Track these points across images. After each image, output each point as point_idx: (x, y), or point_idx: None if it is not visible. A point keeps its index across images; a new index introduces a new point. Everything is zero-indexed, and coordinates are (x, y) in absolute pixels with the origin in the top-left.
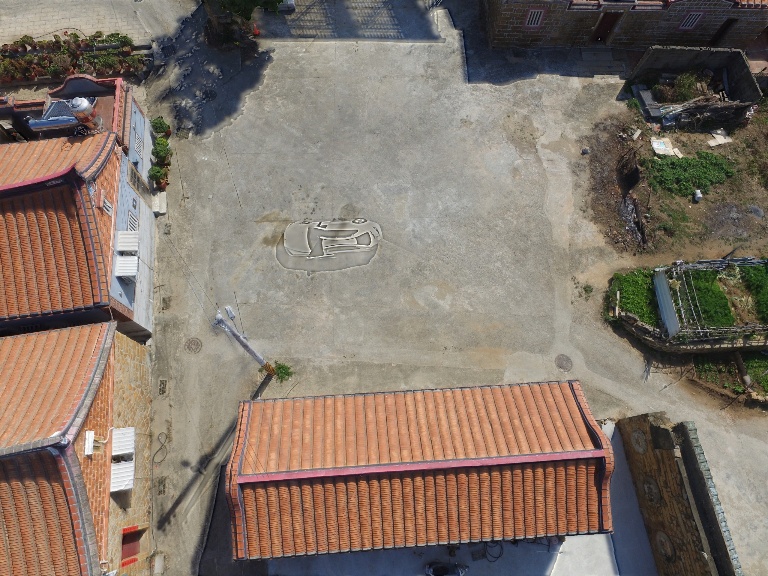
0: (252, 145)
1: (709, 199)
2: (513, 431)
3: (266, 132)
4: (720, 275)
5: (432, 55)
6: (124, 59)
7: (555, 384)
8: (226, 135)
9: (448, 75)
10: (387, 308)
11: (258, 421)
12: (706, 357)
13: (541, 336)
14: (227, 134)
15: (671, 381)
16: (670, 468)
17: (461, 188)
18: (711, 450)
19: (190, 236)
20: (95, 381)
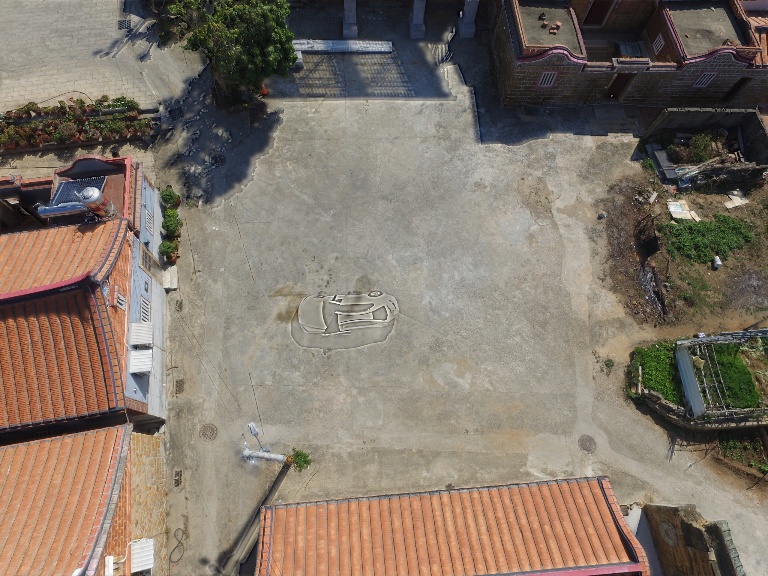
0: (263, 213)
1: (728, 265)
2: (544, 539)
3: (277, 199)
4: (742, 347)
5: (443, 114)
6: (131, 123)
7: (584, 482)
8: (237, 203)
9: (460, 135)
10: (406, 388)
11: (281, 531)
12: (730, 433)
13: (563, 415)
14: (238, 202)
15: (696, 459)
16: (704, 570)
17: (477, 257)
18: (739, 534)
19: (202, 313)
20: (113, 499)
